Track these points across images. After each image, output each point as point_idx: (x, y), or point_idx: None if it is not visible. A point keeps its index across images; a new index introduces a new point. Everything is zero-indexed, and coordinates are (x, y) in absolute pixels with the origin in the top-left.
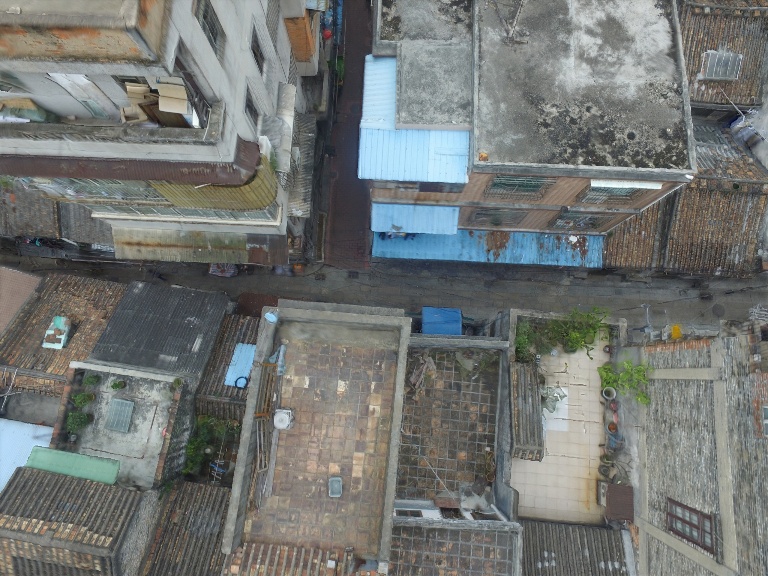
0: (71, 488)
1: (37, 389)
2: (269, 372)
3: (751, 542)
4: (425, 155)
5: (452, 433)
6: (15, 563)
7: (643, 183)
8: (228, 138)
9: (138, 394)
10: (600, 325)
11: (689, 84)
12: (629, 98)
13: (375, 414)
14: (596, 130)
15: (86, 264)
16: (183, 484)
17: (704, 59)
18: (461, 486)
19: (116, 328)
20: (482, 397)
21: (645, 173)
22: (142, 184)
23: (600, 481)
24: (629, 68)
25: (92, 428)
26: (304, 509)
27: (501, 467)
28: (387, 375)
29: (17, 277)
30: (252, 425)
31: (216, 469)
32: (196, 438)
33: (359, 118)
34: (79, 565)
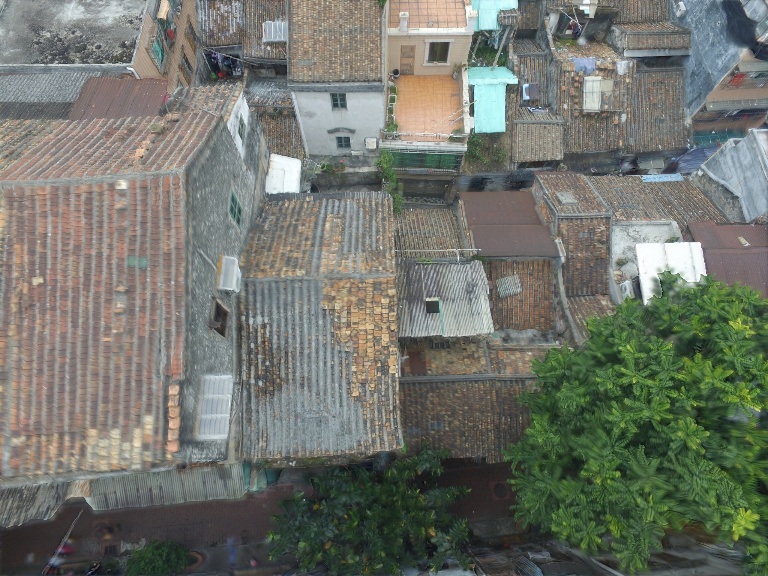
0: None
1: None
2: None
3: None
4: None
5: None
6: None
7: None
8: None
9: None
10: None
11: (257, 46)
12: (105, 25)
13: None
14: (74, 44)
15: None
16: None
17: (264, 27)
18: None
19: None
20: None
21: (98, 68)
22: None
23: None
24: (112, 7)
25: None
26: None
27: None
28: None
29: None
30: None
31: None
32: None
33: None
34: None
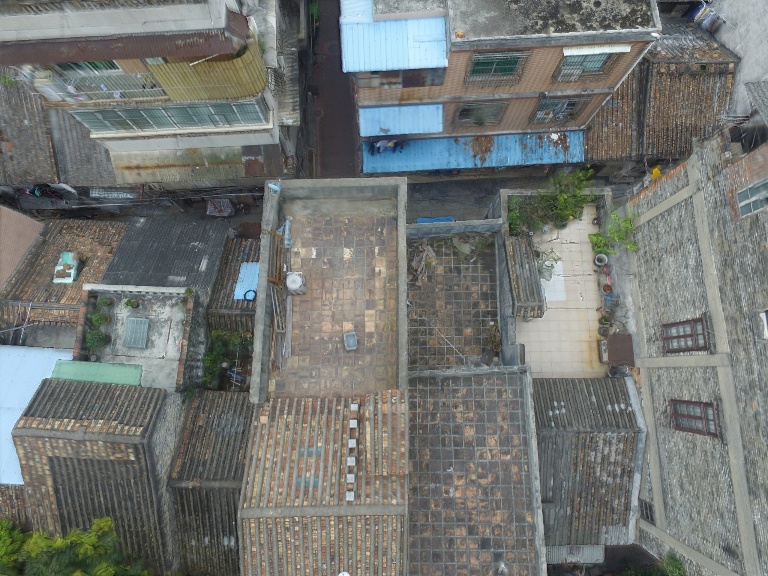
0: (98, 391)
1: (53, 320)
2: (277, 243)
3: (738, 318)
4: (404, 44)
5: (456, 313)
6: (51, 463)
7: (613, 47)
8: (218, 0)
9: (152, 312)
10: (587, 200)
11: None
12: None
13: (381, 275)
14: (564, 2)
15: (86, 209)
16: (204, 392)
17: None
18: (470, 359)
19: (123, 258)
20: (482, 277)
21: (613, 36)
22: (139, 67)
23: (601, 341)
24: None
25: (110, 348)
26: (323, 365)
27: (506, 333)
28: (389, 239)
29: (21, 219)
30: (266, 287)
31: (234, 376)
32: (212, 352)
33: (338, 57)
34: (113, 456)
